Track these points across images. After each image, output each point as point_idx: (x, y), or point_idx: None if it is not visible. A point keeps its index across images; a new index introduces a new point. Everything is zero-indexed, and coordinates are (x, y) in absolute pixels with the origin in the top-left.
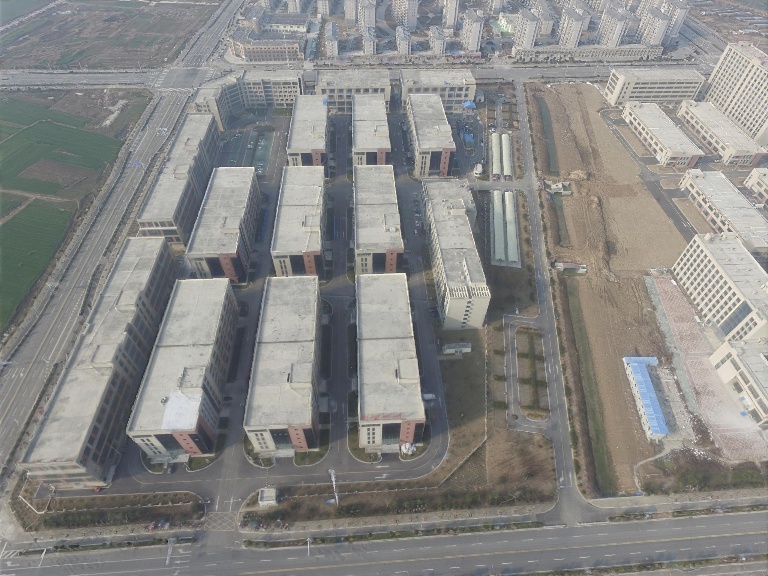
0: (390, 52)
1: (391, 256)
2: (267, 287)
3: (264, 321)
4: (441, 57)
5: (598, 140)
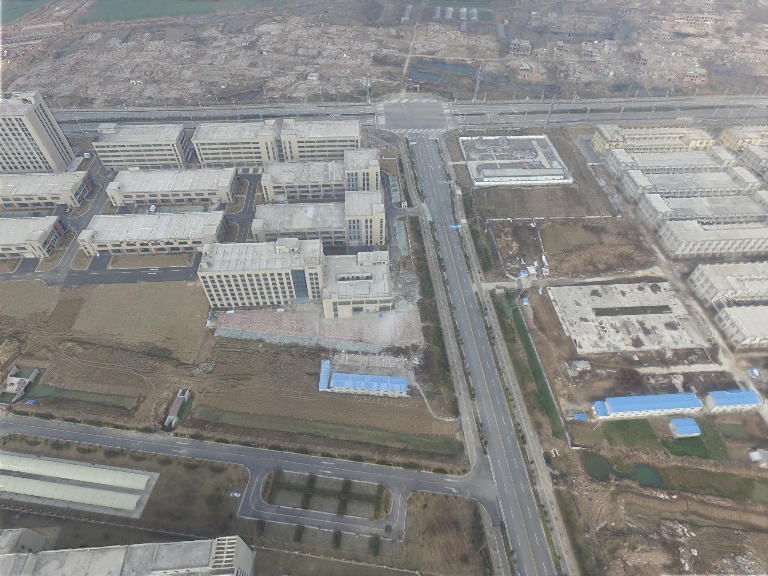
0: None
1: None
2: None
3: None
4: None
5: None
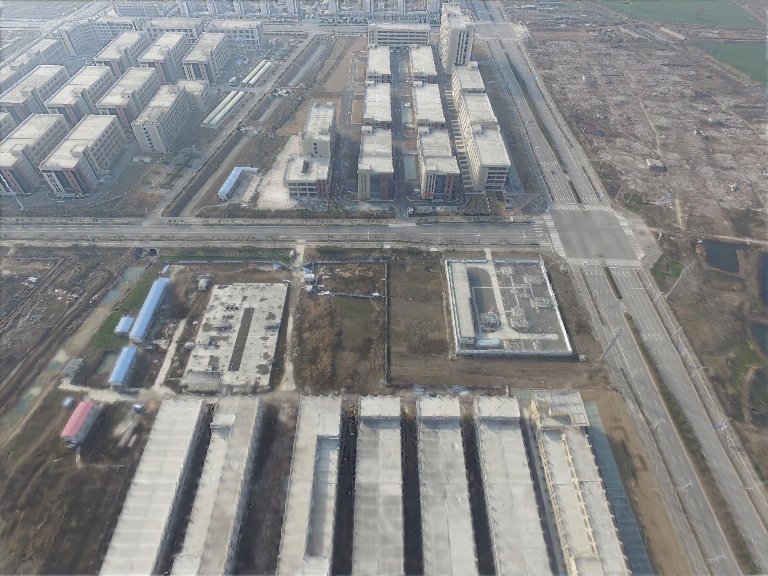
0: (230, 13)
1: (120, 111)
2: (30, 118)
3: (17, 131)
4: (267, 17)
5: (337, 69)
